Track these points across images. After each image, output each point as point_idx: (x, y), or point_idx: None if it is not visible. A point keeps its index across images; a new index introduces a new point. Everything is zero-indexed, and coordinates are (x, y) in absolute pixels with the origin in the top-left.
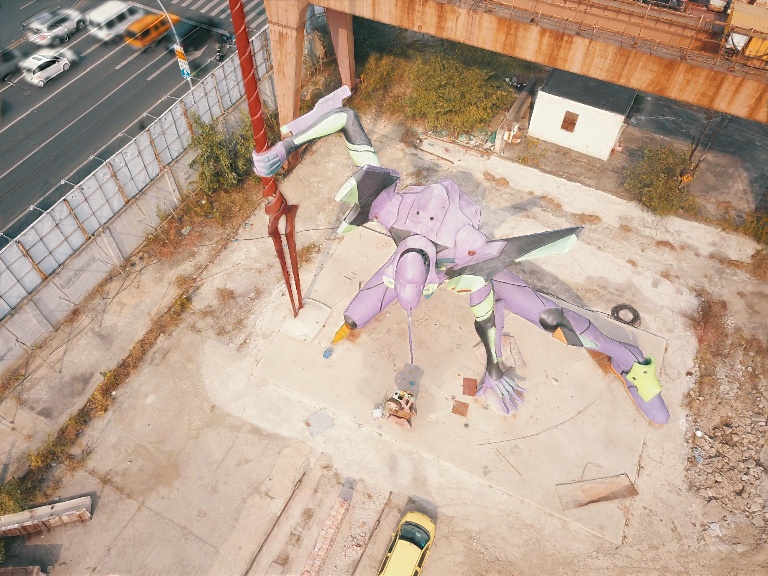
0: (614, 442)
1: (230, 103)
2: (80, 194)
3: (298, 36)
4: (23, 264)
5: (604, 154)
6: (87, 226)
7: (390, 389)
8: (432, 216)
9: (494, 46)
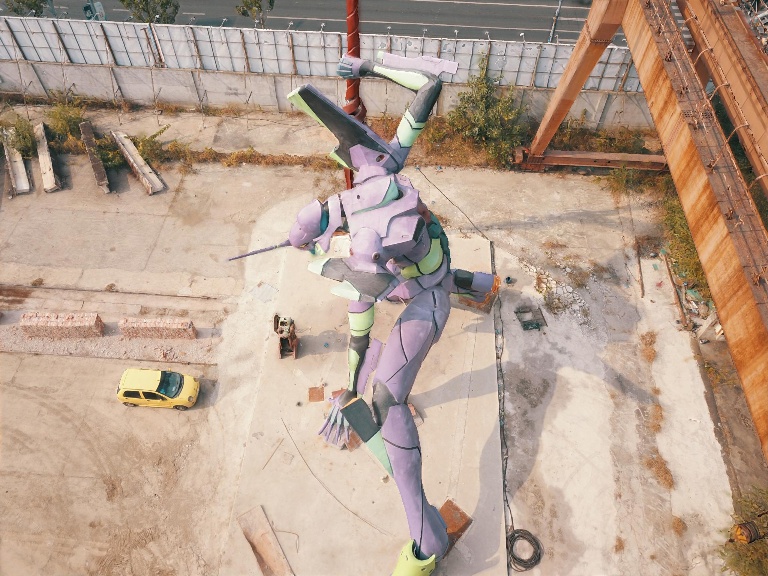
0: (333, 561)
1: (547, 85)
2: None
3: (591, 49)
4: (287, 52)
5: None
6: None
7: (314, 330)
8: (360, 195)
9: (675, 170)
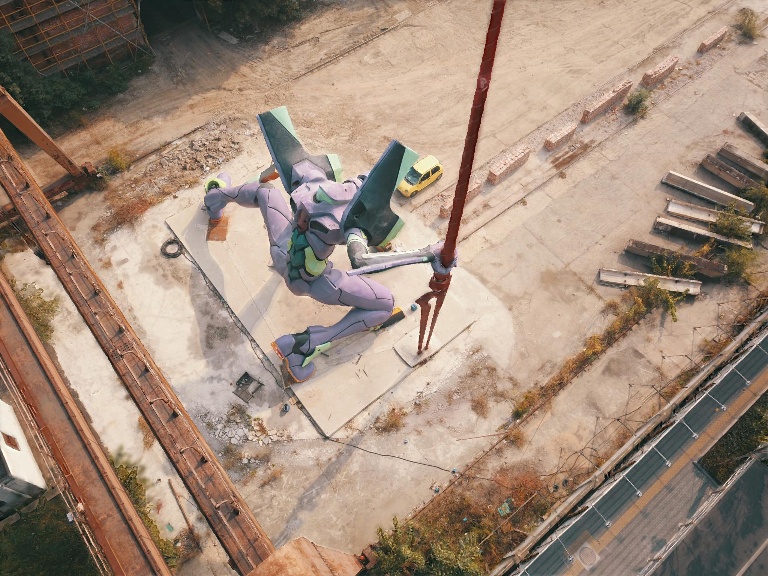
0: None
1: None
2: None
3: None
4: None
5: (8, 408)
6: None
7: None
8: None
9: None
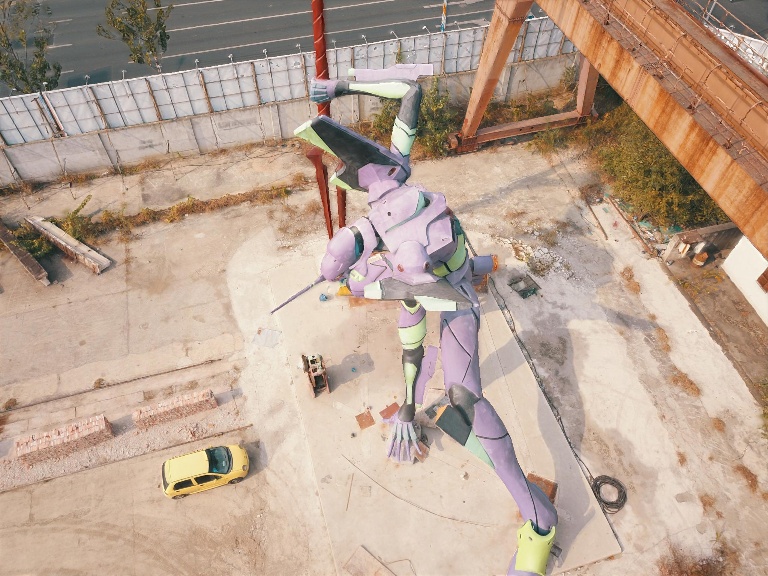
0: (452, 571)
1: (455, 69)
2: (266, 66)
3: (510, 28)
4: (199, 91)
5: None
6: (264, 94)
7: (335, 359)
8: (391, 212)
9: (648, 118)
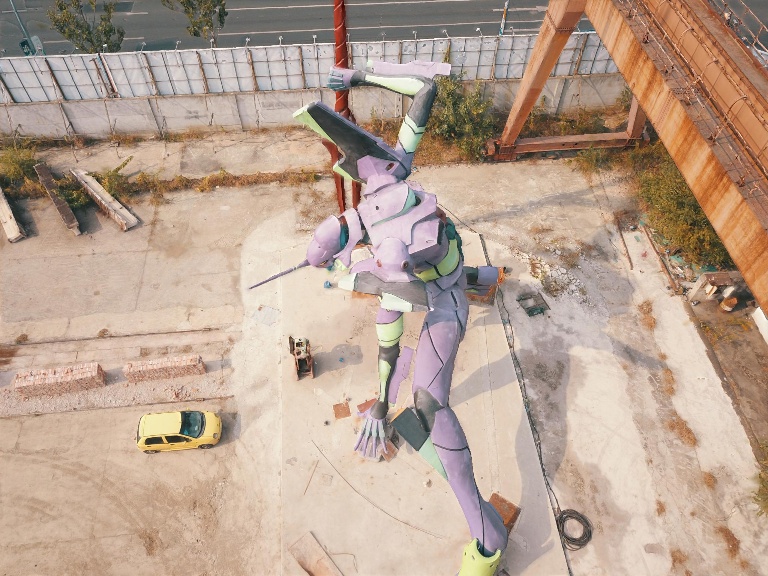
0: (394, 574)
1: (506, 76)
2: (314, 51)
3: (557, 37)
4: (246, 69)
5: None
6: (309, 79)
7: (326, 347)
8: (379, 206)
9: (671, 146)
